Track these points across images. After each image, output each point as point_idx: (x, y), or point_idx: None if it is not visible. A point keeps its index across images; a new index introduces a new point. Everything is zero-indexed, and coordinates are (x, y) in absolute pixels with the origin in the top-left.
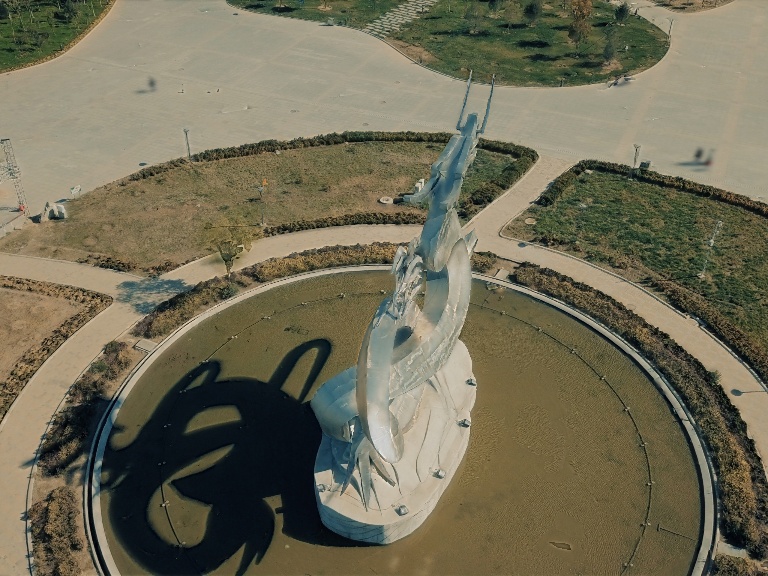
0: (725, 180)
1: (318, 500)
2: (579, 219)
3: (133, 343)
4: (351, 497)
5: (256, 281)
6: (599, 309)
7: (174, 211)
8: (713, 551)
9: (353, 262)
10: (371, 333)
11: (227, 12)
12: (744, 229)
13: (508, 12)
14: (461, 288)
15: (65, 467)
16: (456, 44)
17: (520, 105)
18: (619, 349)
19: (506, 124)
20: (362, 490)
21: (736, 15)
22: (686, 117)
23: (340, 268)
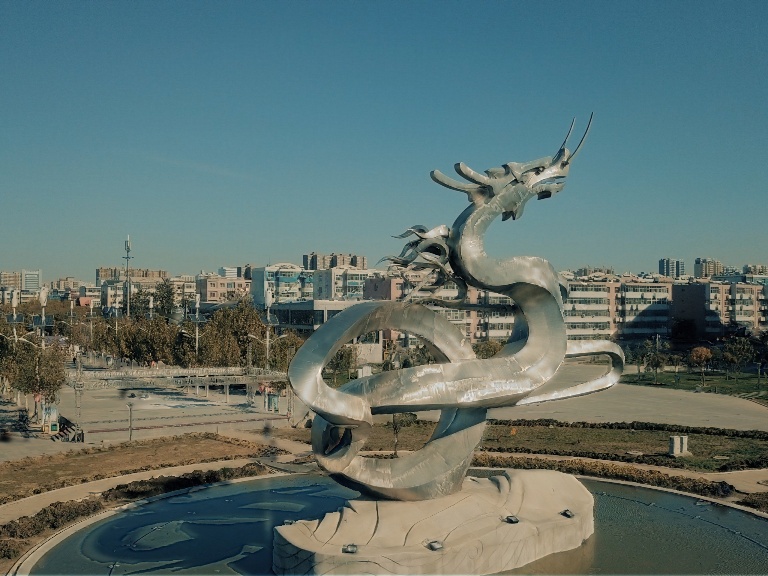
0: None
1: None
2: None
3: None
4: (306, 526)
5: None
6: None
7: (410, 436)
8: None
9: None
10: None
11: None
12: None
13: None
14: (545, 356)
15: (118, 497)
16: None
17: None
18: None
19: None
20: None
21: None
22: None
23: None
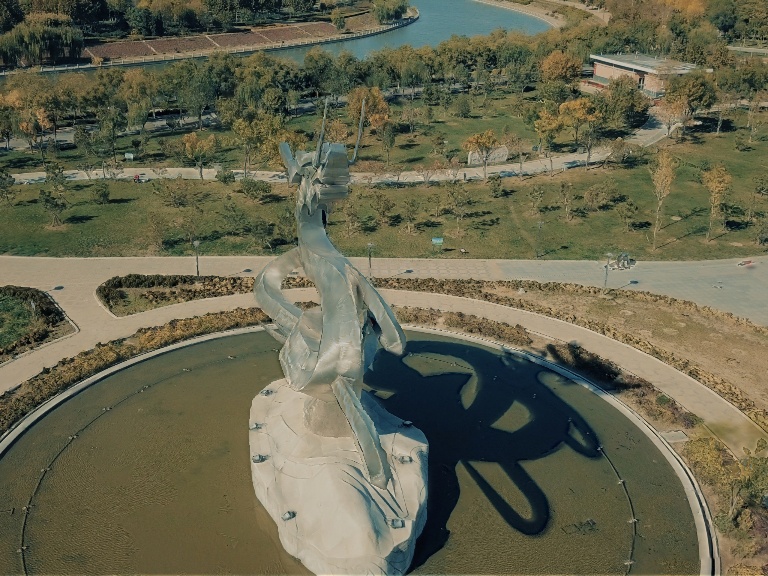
0: None
1: None
2: None
3: (689, 433)
4: None
5: None
6: None
7: None
8: None
9: None
10: None
11: None
12: None
13: None
14: None
15: None
16: None
17: None
18: None
19: None
20: None
21: None
22: None
23: None
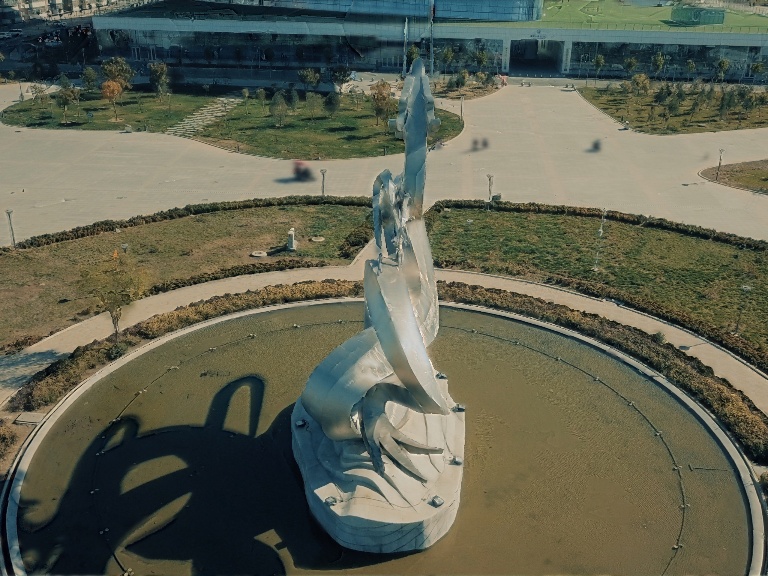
0: (570, 202)
1: (329, 518)
2: (460, 244)
3: (12, 419)
4: (373, 500)
5: (145, 339)
6: (523, 305)
7: (13, 293)
8: (753, 475)
9: (251, 306)
10: (378, 279)
11: (7, 131)
12: (609, 232)
13: (311, 103)
14: (425, 259)
15: None
16: (267, 135)
17: (354, 171)
18: (559, 334)
19: (348, 185)
20: (402, 470)
21: (506, 99)
22: (509, 165)
23: (238, 313)
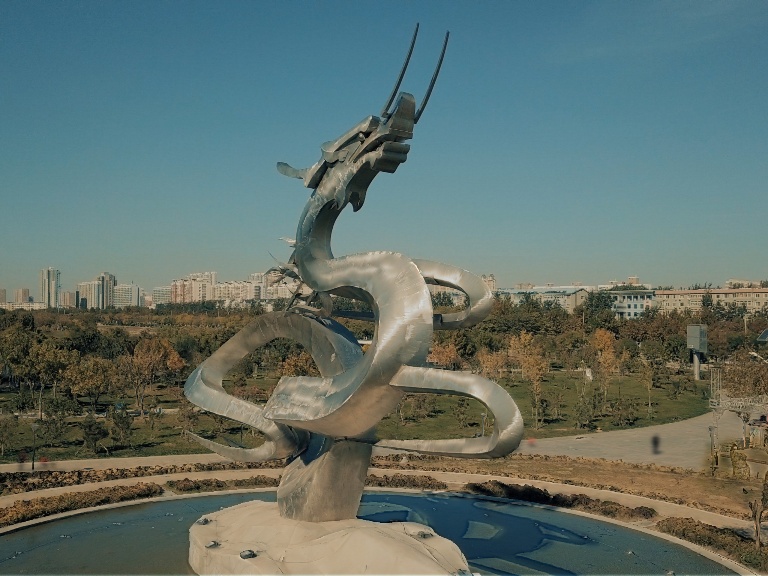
0: None
1: None
2: None
3: None
4: None
5: None
6: None
7: None
8: None
9: None
10: None
11: None
12: None
13: None
14: None
15: None
16: None
17: None
18: None
19: None
20: None
21: None
22: None
23: None
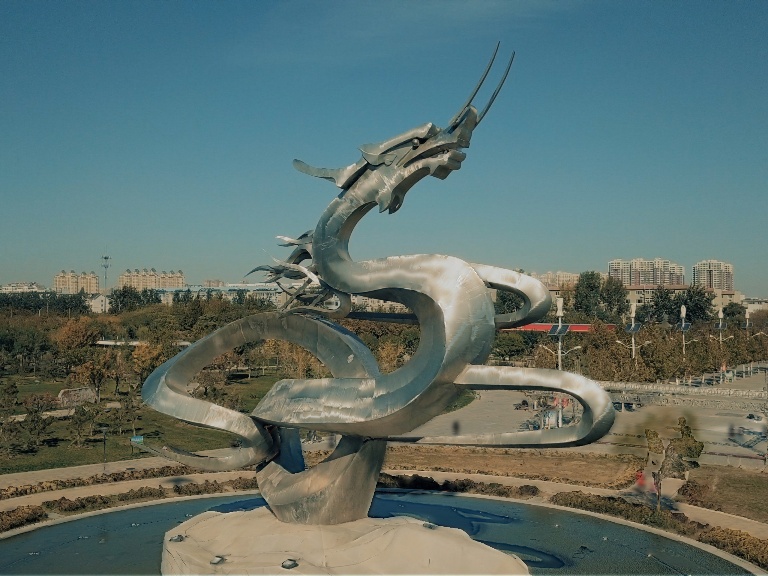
0: None
1: None
2: None
3: None
4: (214, 516)
5: None
6: None
7: None
8: None
9: None
10: None
11: None
12: None
13: None
14: (413, 382)
15: None
16: None
17: None
18: None
19: None
20: None
21: None
22: None
23: None
